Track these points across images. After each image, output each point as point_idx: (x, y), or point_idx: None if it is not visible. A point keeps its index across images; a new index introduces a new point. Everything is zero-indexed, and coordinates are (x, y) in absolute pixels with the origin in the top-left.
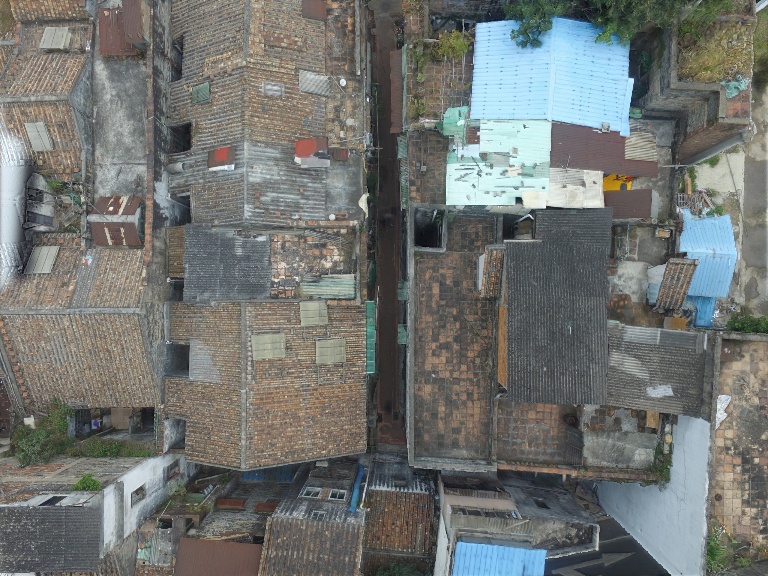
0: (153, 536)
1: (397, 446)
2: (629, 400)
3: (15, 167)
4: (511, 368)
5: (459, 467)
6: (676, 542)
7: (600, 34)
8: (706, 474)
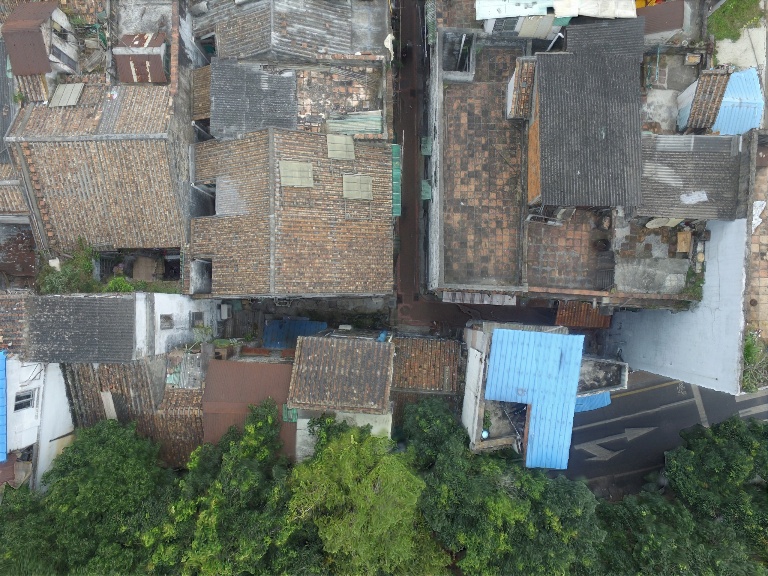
0: (182, 361)
1: (417, 327)
2: (662, 209)
3: (39, 2)
4: (544, 172)
5: (490, 288)
6: (710, 352)
7: None
8: (743, 269)
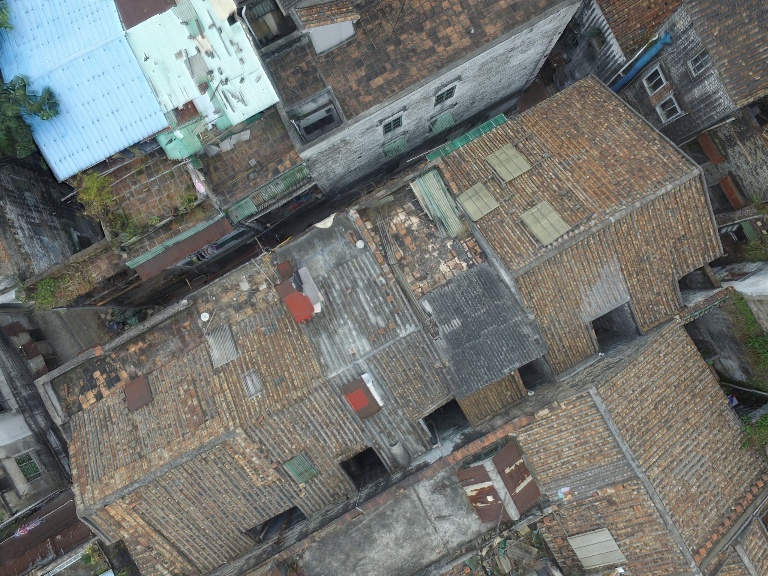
0: None
1: None
2: None
3: None
4: None
5: None
6: None
7: None
8: None
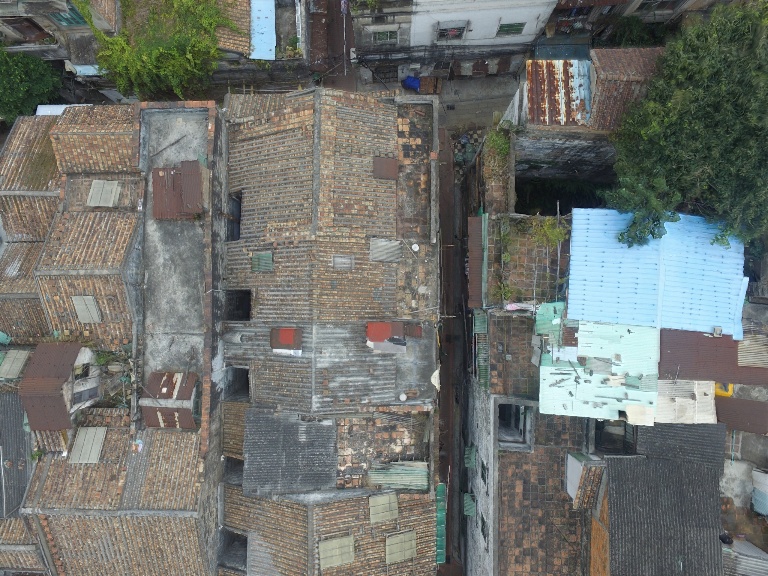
0: None
1: None
2: None
3: (60, 343)
4: None
5: None
6: None
7: (718, 238)
8: None
